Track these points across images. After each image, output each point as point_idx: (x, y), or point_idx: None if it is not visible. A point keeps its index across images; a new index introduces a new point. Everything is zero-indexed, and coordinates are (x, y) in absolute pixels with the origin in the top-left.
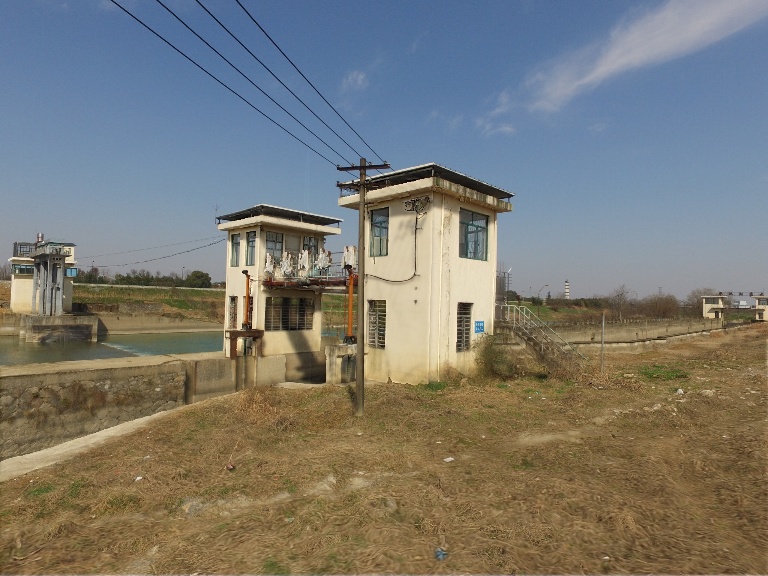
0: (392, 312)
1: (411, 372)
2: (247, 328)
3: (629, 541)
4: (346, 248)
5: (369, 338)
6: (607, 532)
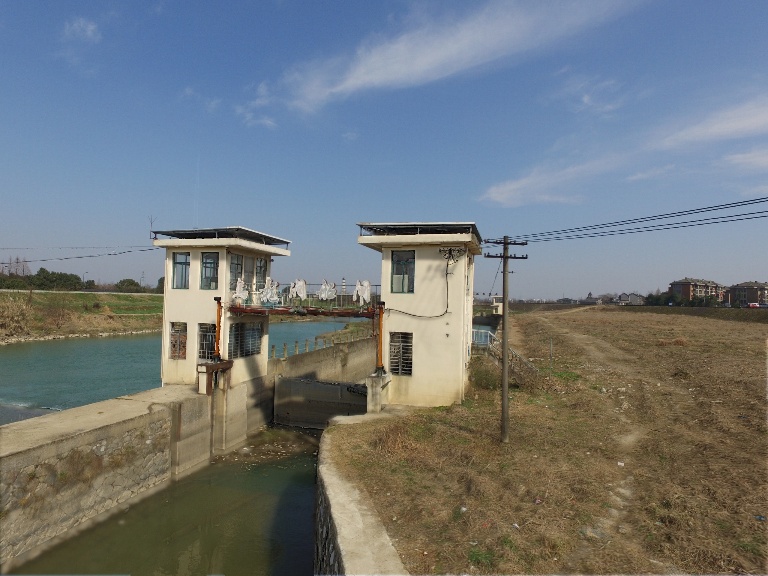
0: (420, 343)
1: (443, 395)
2: (220, 360)
3: None
4: (359, 282)
5: (390, 366)
6: None
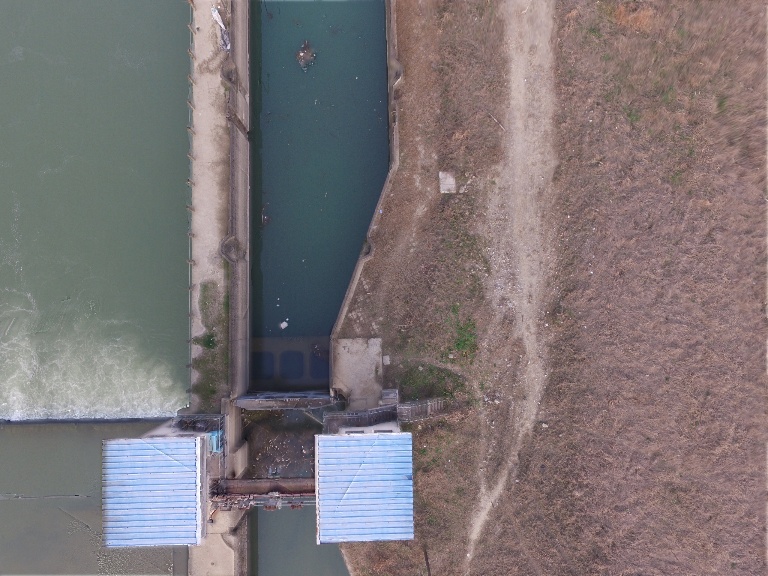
0: None
1: None
2: None
3: (518, 573)
4: None
5: None
6: (514, 572)
